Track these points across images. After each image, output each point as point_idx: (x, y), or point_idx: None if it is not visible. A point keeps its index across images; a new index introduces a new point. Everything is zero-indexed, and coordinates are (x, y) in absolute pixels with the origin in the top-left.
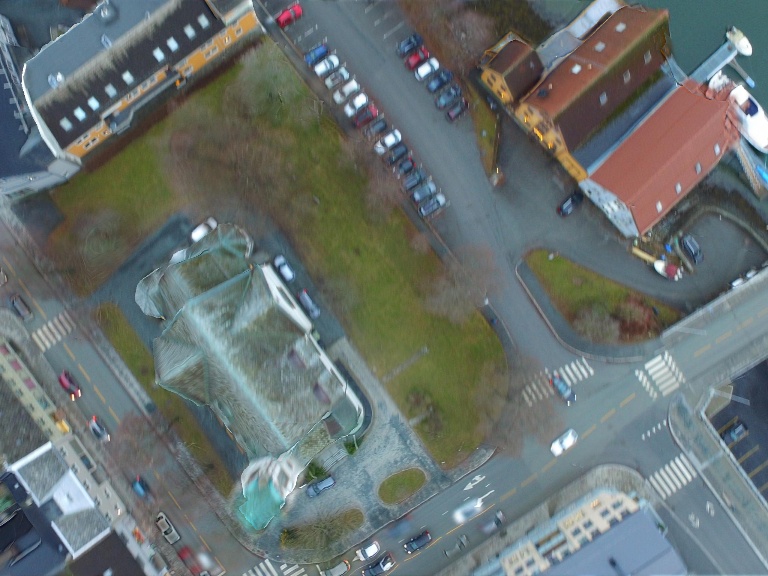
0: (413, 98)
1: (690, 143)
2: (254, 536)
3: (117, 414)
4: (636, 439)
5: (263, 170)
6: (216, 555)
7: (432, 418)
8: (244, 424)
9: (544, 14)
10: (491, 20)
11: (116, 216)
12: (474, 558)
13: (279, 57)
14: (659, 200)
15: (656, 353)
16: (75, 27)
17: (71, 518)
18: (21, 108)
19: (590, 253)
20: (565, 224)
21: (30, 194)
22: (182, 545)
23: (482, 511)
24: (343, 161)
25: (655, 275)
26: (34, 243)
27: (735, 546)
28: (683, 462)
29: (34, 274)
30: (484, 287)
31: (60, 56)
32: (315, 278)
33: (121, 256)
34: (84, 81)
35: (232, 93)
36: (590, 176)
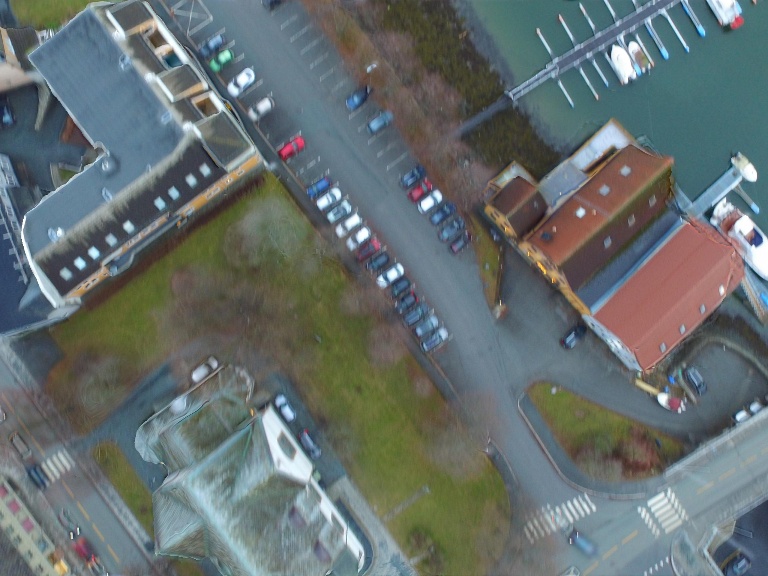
0: (416, 230)
1: (695, 289)
2: None
3: (116, 552)
4: None
5: (264, 310)
6: None
7: (433, 559)
8: None
9: (548, 139)
10: (495, 146)
11: (116, 357)
12: None
13: (281, 193)
14: (663, 342)
15: (659, 490)
16: (75, 178)
17: None
18: (21, 258)
19: (593, 385)
20: (568, 356)
21: (29, 333)
22: None
23: None
24: (345, 298)
25: (658, 407)
26: (33, 380)
27: None
28: None
29: (33, 412)
30: (486, 431)
31: (60, 208)
32: (316, 417)
33: (121, 394)
34: (84, 233)
35: (233, 234)
36: (594, 315)
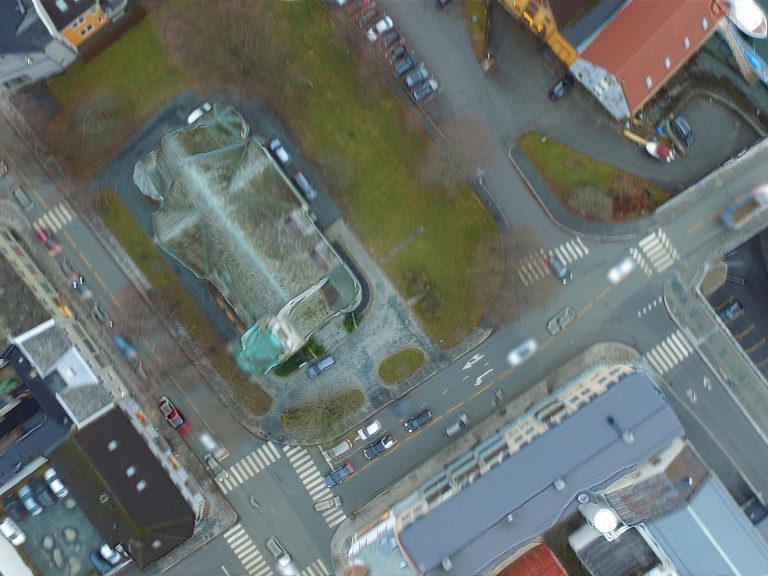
0: None
1: (678, 14)
2: (256, 418)
3: (118, 300)
4: (632, 316)
5: (257, 54)
6: (219, 438)
7: (429, 296)
8: (243, 287)
9: None
10: None
11: (113, 102)
12: (474, 436)
13: None
14: (649, 75)
15: (650, 231)
16: None
17: (75, 391)
18: None
19: (582, 137)
20: (557, 108)
21: (28, 84)
22: (185, 428)
23: (481, 389)
24: (336, 46)
25: (647, 157)
26: (33, 133)
27: (733, 420)
28: (679, 338)
29: (34, 164)
30: (478, 163)
31: None
32: (311, 161)
33: (119, 144)
34: None
35: None
36: (580, 54)
